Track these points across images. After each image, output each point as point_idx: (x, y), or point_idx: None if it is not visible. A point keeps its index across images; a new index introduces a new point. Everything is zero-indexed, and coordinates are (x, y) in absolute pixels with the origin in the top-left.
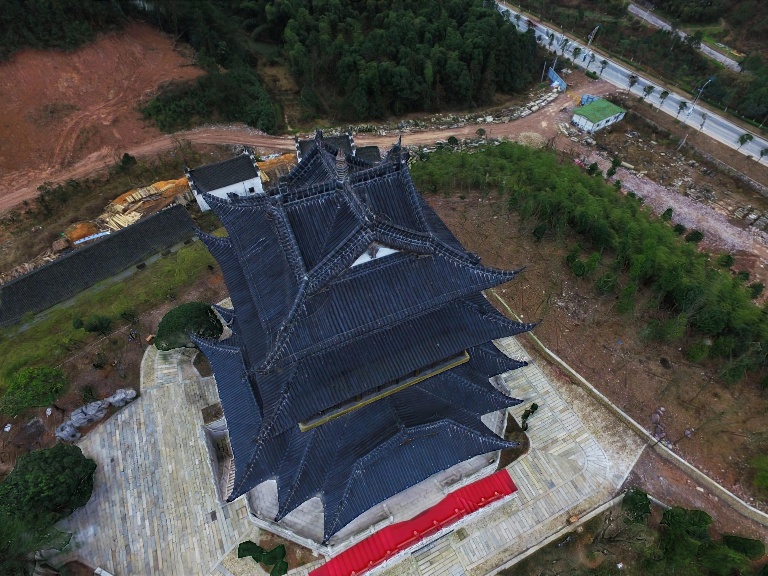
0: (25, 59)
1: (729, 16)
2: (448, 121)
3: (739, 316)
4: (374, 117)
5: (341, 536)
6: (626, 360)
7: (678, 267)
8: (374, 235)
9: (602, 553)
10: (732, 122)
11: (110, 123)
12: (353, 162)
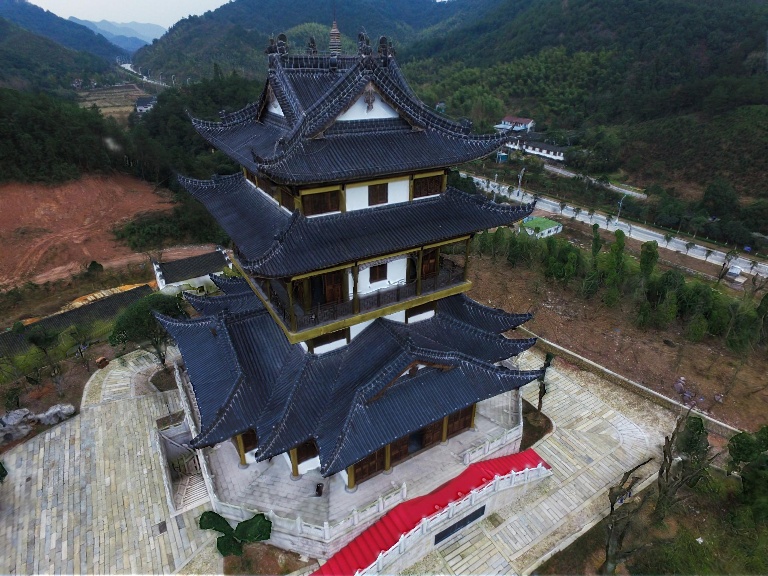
0: (7, 191)
1: (625, 167)
2: None
3: (723, 301)
4: None
5: (340, 519)
6: (629, 343)
7: (651, 245)
8: (371, 74)
9: (673, 520)
10: (654, 231)
11: (81, 242)
12: None
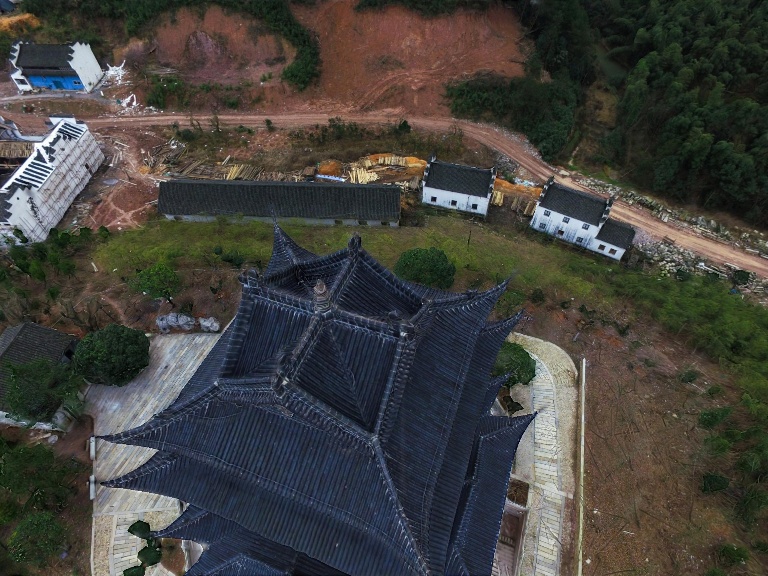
0: (393, 12)
1: None
2: (765, 247)
3: None
4: (671, 195)
5: None
6: None
7: None
8: (280, 399)
9: None
10: None
11: (417, 89)
12: (395, 285)
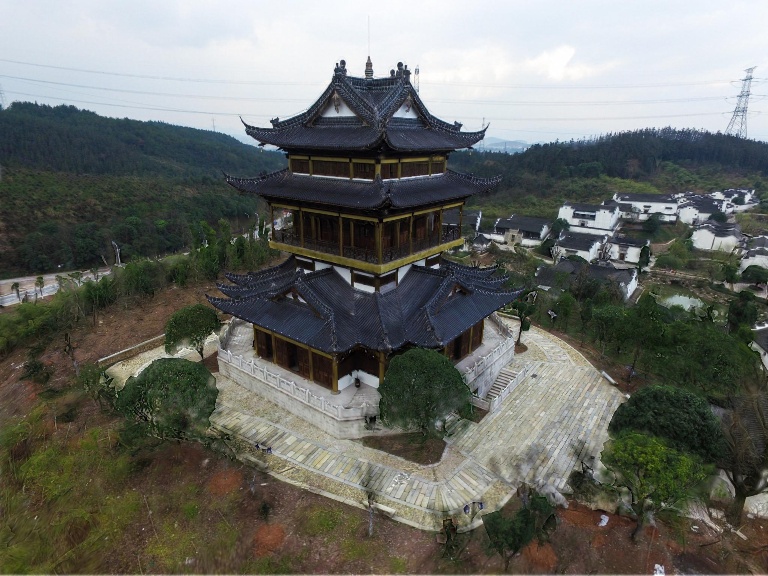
0: None
1: None
2: None
3: None
4: None
5: None
6: None
7: None
8: None
9: None
10: None
11: None
12: None
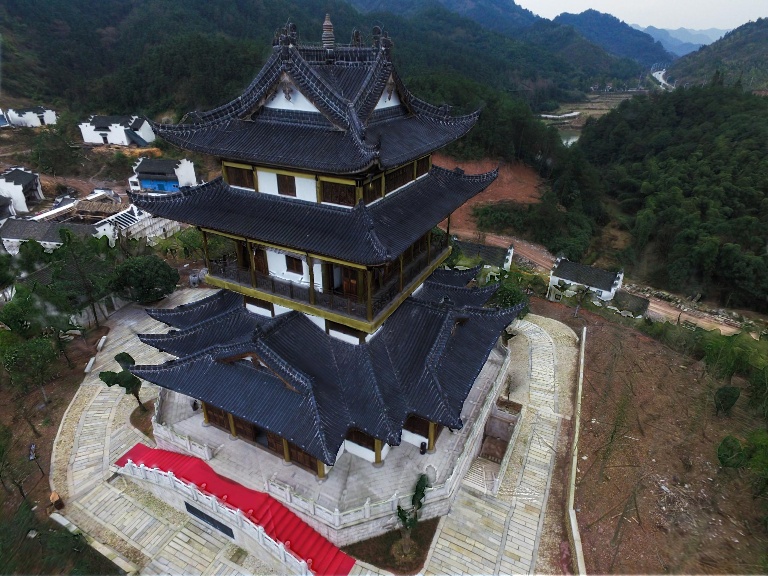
0: None
1: None
2: None
3: None
4: None
5: (174, 430)
6: None
7: None
8: (285, 64)
9: None
10: None
11: None
12: None
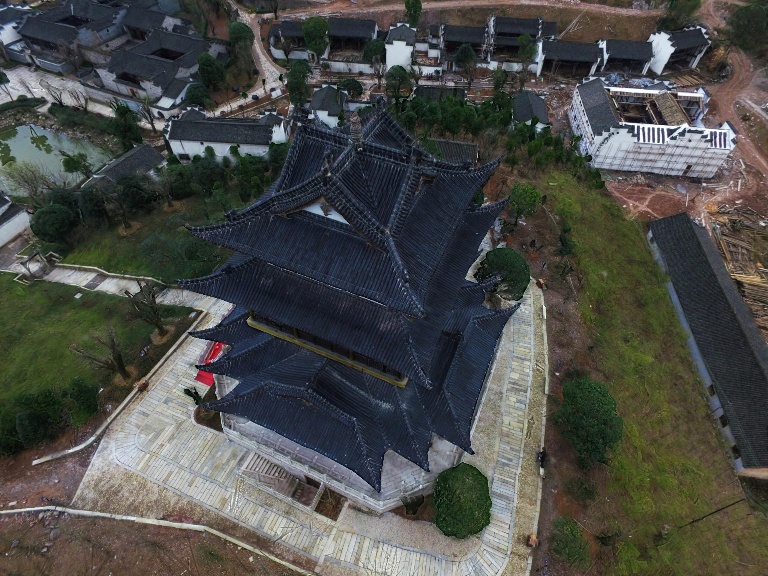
0: None
1: None
2: None
3: None
4: None
5: None
6: None
7: None
8: None
9: None
10: None
11: None
12: None
